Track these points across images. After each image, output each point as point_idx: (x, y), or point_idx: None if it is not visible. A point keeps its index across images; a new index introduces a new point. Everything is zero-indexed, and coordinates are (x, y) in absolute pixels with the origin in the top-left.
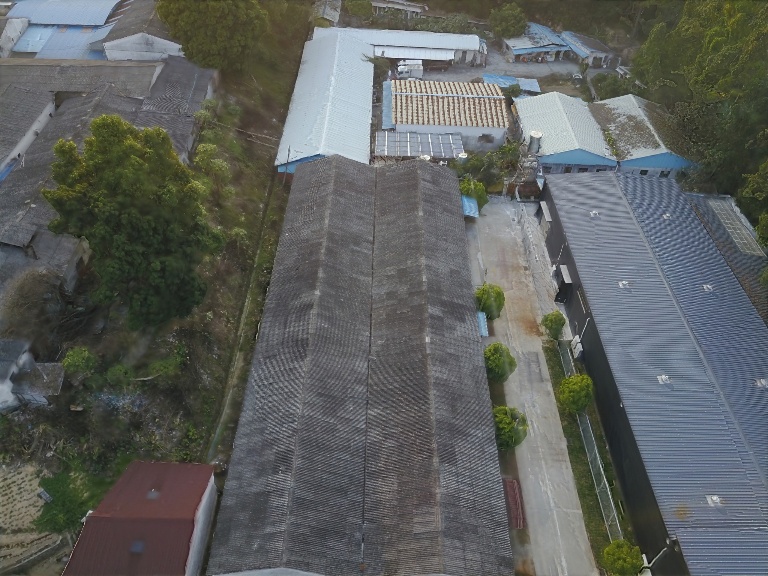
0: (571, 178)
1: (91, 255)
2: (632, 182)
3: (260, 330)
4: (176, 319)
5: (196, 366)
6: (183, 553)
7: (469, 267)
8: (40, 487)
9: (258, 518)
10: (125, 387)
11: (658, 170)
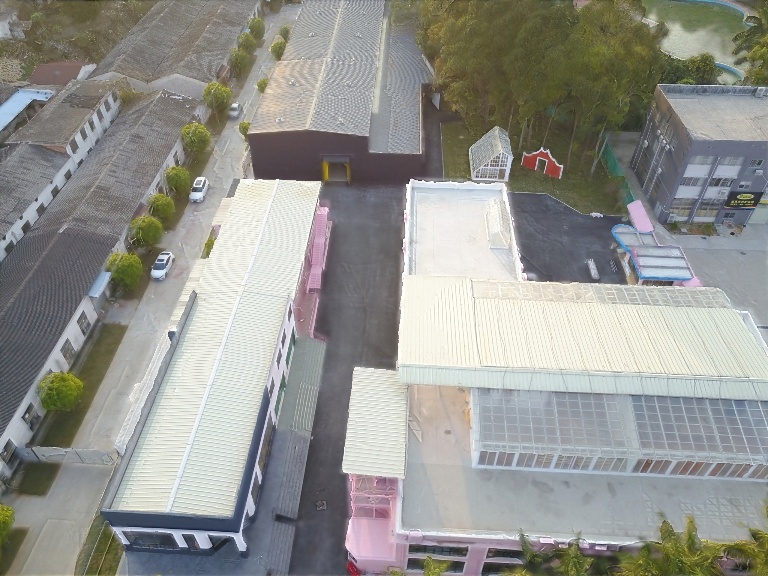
0: None
1: (52, 1)
2: None
3: (131, 30)
4: (92, 28)
5: (99, 44)
6: (76, 74)
7: (249, 13)
8: (21, 68)
9: None
10: (61, 41)
11: None
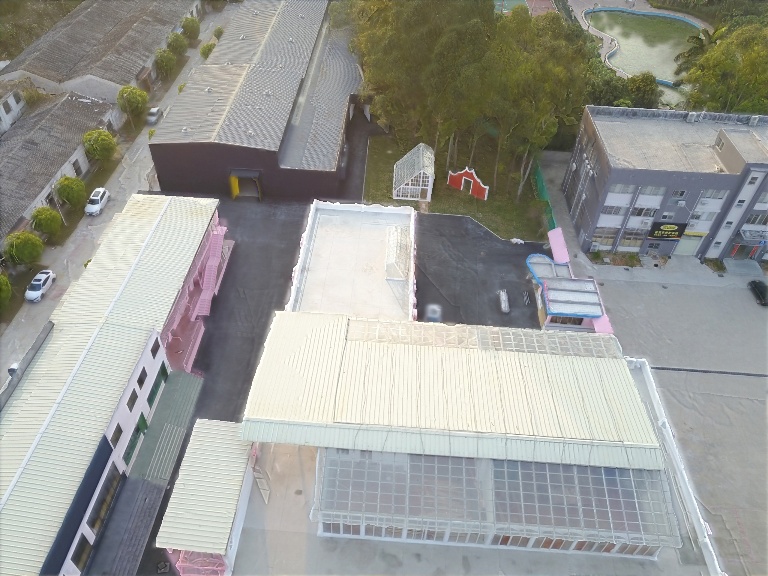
0: None
1: None
2: None
3: (55, 25)
4: (13, 21)
5: (19, 39)
6: None
7: (185, 12)
8: None
9: (19, 63)
10: None
11: None
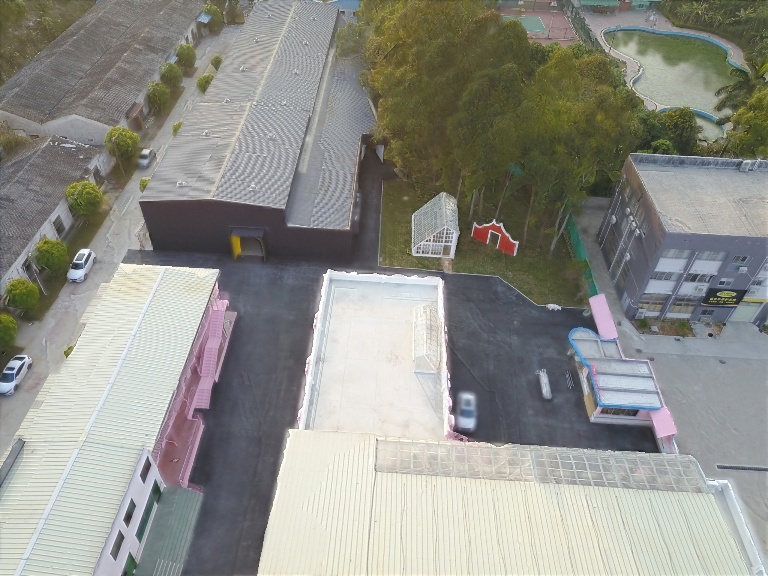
0: (270, 2)
1: None
2: (307, 4)
3: (38, 54)
4: None
5: None
6: None
7: (179, 38)
8: None
9: None
10: None
11: (351, 11)
